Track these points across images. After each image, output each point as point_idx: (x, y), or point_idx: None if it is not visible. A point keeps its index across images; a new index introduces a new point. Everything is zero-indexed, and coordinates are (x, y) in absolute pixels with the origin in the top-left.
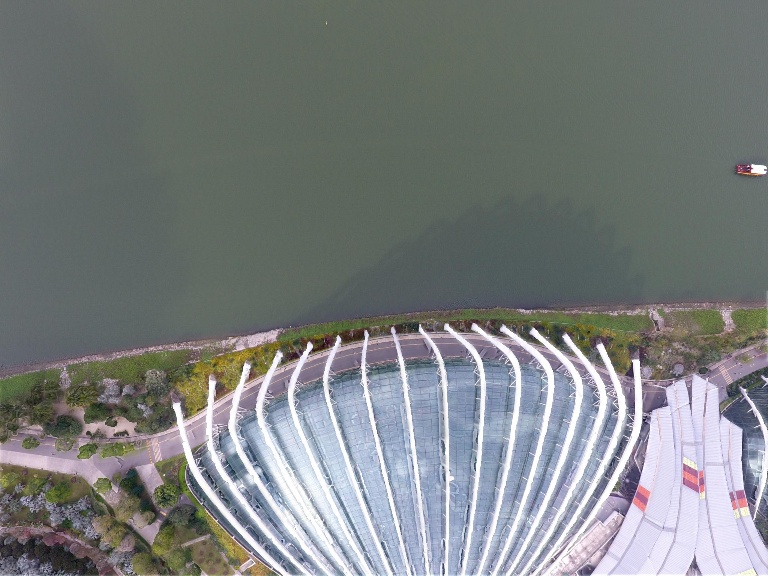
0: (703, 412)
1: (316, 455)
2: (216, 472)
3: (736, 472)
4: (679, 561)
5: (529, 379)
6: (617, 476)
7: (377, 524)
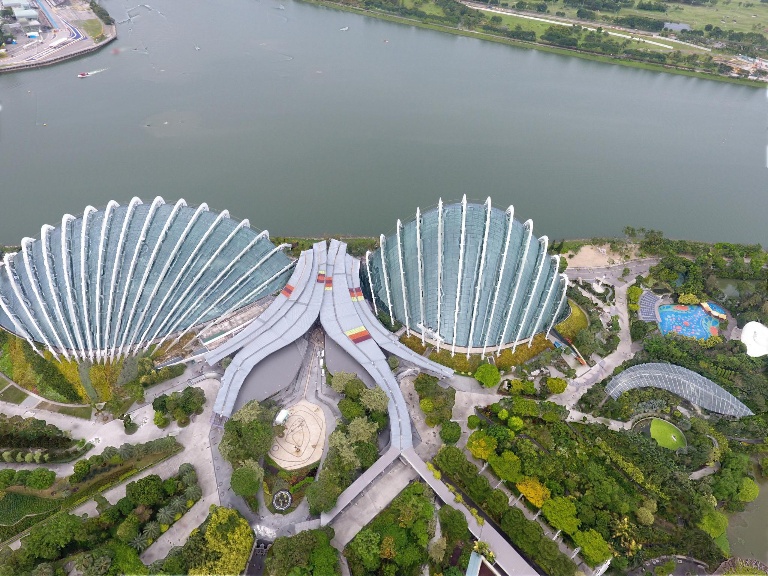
0: (336, 253)
1: (68, 236)
2: (2, 272)
3: (355, 279)
4: (307, 320)
5: (212, 213)
6: (272, 278)
7: (88, 269)
